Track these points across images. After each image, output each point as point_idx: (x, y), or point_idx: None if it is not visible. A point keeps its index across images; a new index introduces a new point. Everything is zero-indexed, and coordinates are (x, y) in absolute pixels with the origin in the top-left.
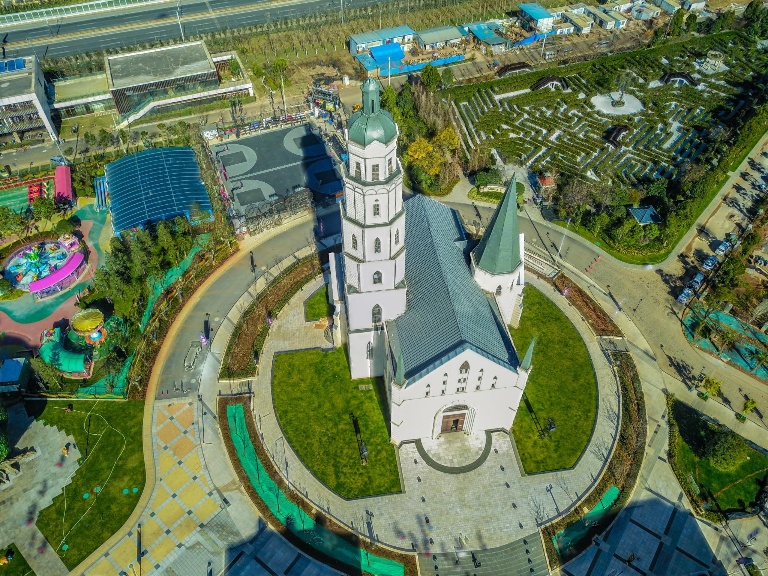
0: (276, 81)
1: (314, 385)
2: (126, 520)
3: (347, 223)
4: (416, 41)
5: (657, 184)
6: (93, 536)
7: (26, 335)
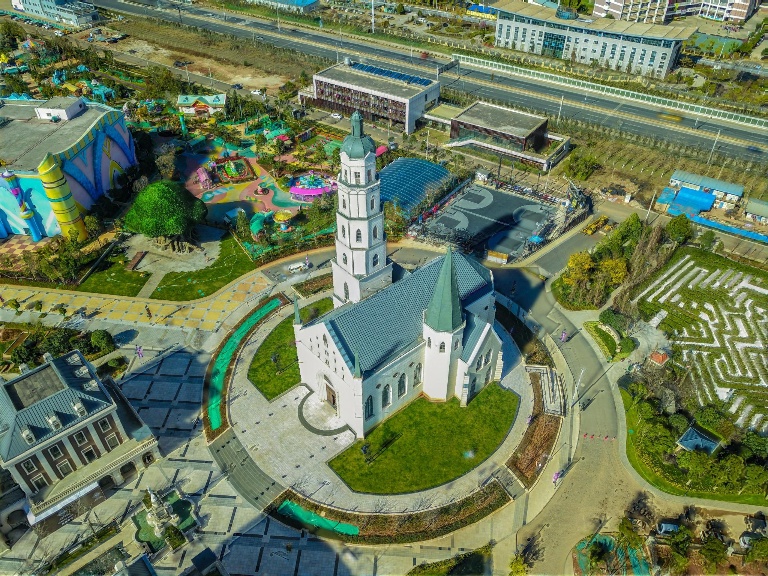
0: (571, 170)
1: None
2: (185, 301)
3: None
4: None
5: (764, 440)
6: (170, 295)
7: None
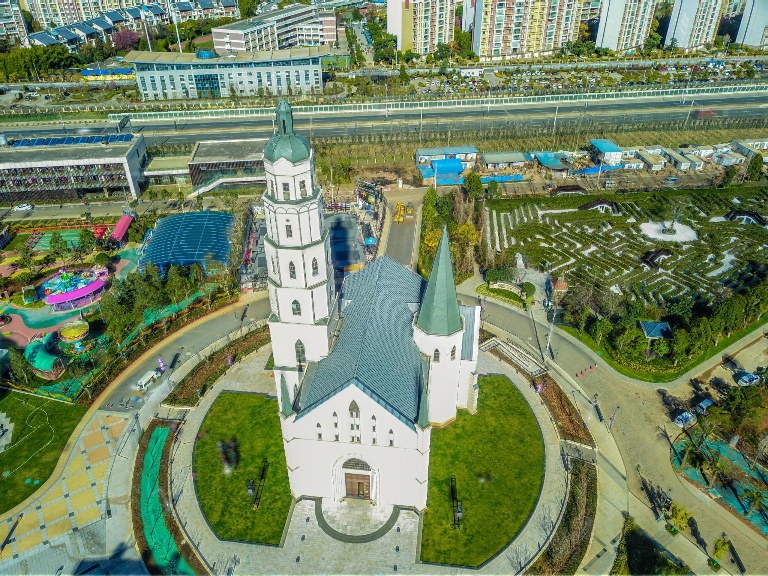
0: (336, 176)
1: (243, 425)
2: (14, 507)
3: (267, 244)
4: (480, 161)
5: (682, 304)
6: None
7: (27, 337)
